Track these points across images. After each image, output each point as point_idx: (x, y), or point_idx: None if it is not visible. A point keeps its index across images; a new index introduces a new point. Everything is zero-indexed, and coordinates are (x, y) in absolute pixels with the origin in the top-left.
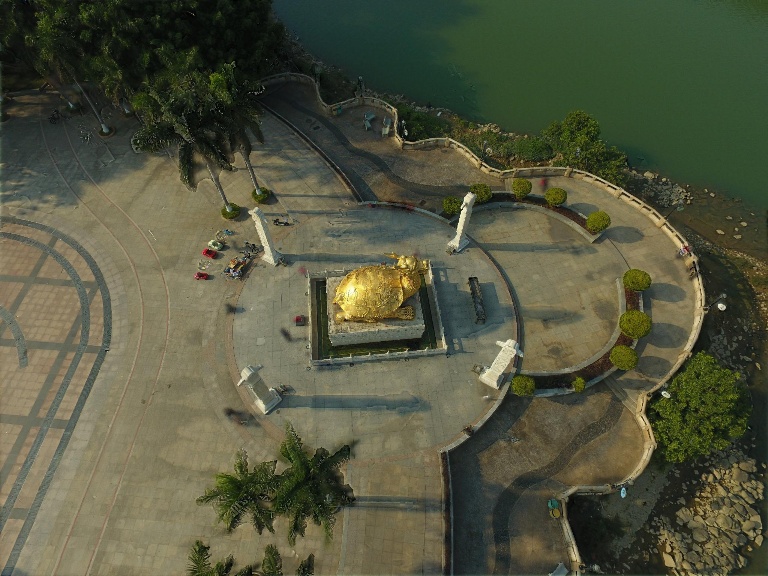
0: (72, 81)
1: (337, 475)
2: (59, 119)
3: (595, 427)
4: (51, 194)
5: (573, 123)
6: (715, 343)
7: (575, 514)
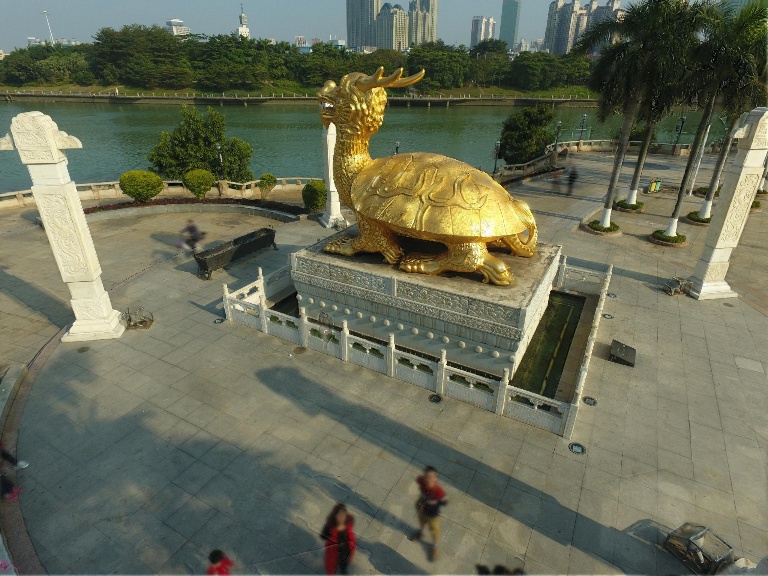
0: None
1: None
2: None
3: None
4: None
5: None
6: None
7: None
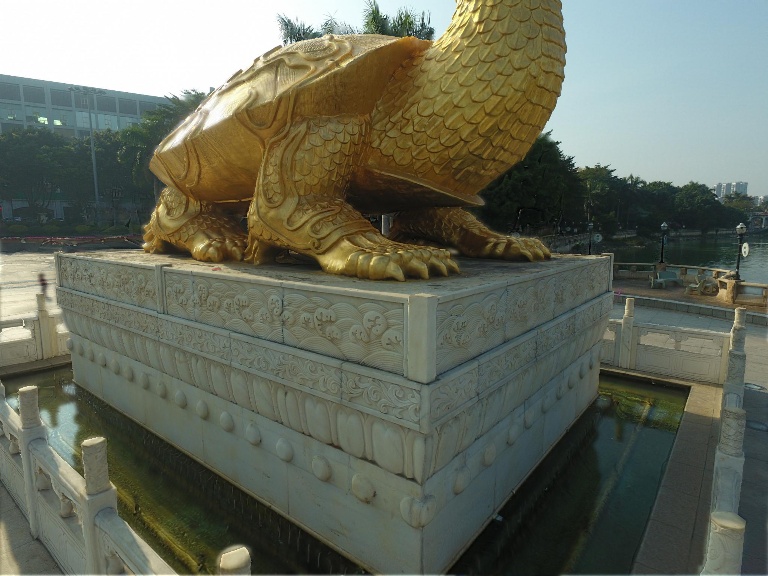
0: None
1: None
2: None
3: None
4: None
5: None
6: None
7: None
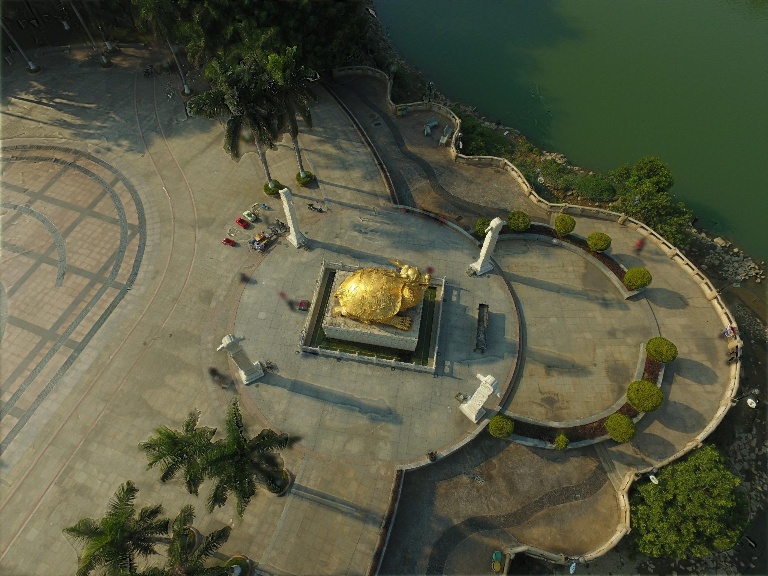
0: (165, 41)
1: (275, 460)
2: (152, 74)
3: (569, 491)
4: (125, 139)
5: (644, 169)
6: (740, 441)
7: (522, 574)
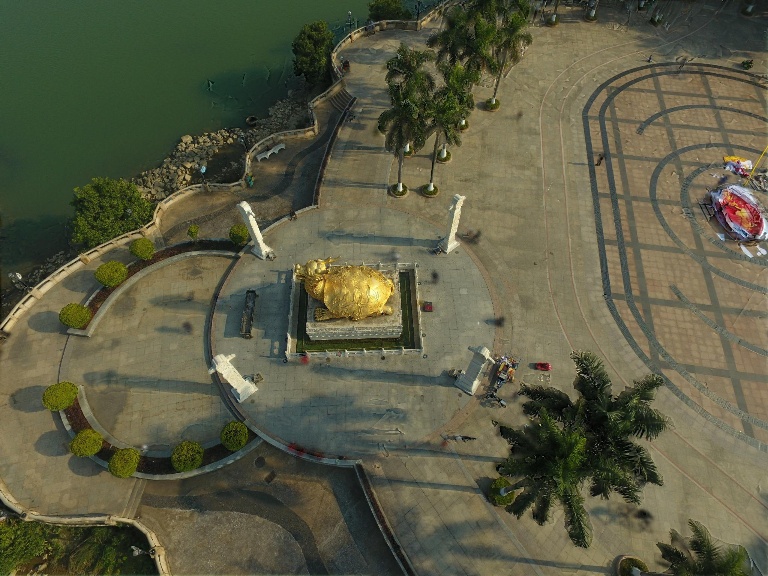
0: None
1: None
2: None
3: (194, 223)
4: None
5: None
6: None
7: None
